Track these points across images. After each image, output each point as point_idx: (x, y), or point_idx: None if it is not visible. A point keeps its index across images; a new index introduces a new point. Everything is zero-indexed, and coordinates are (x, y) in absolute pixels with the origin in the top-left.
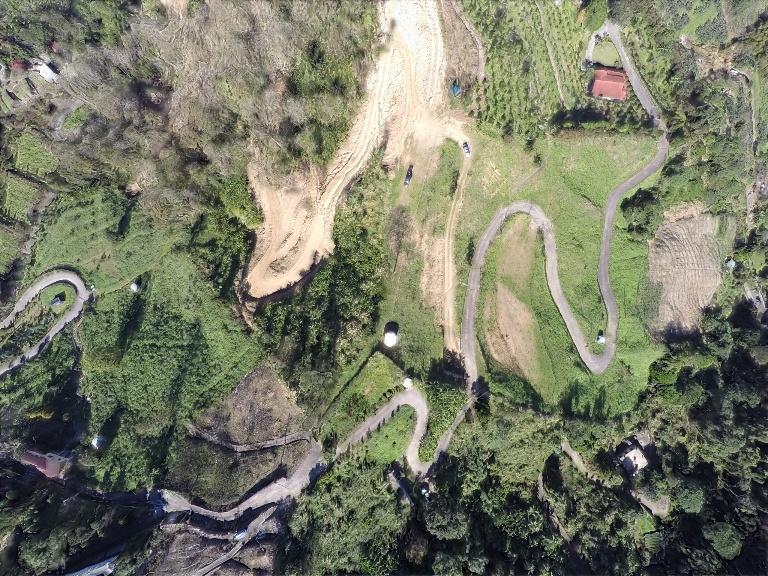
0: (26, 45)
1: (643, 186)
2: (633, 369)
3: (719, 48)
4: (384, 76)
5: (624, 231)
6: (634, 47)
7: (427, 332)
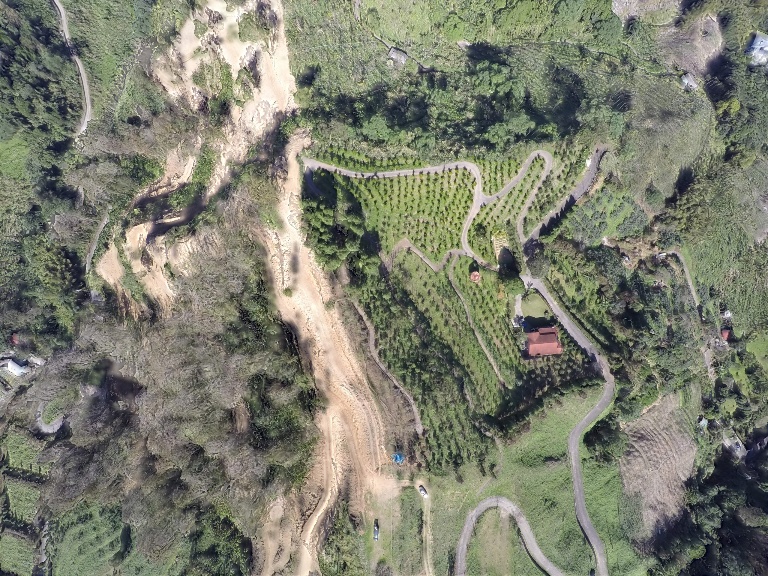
0: None
1: (600, 418)
2: None
3: (643, 231)
4: (330, 437)
5: (592, 461)
6: (560, 283)
7: None
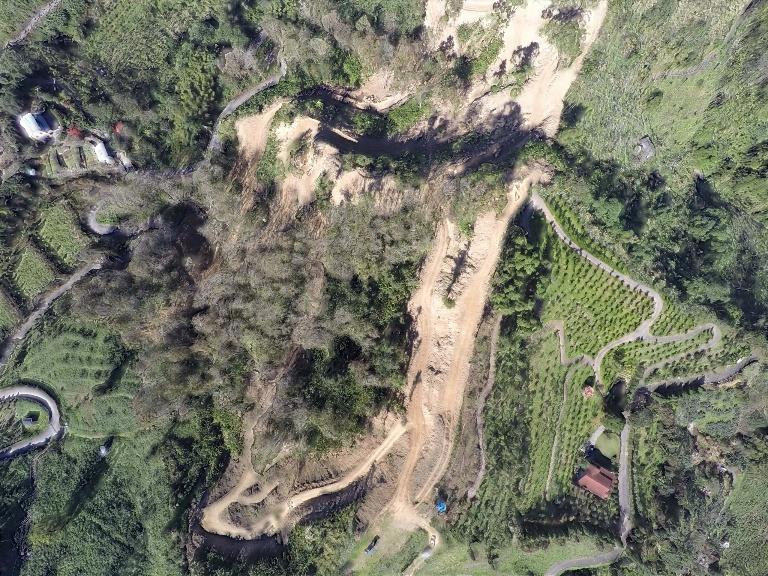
0: (91, 115)
1: None
2: None
3: (722, 439)
4: (389, 444)
5: None
6: (639, 439)
7: None
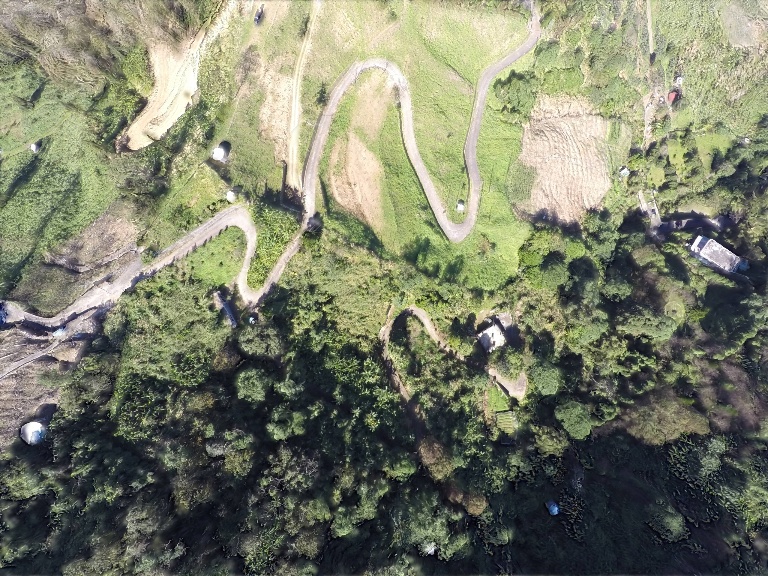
0: None
1: (517, 68)
2: (500, 250)
3: None
4: None
5: (497, 112)
6: None
7: (265, 161)
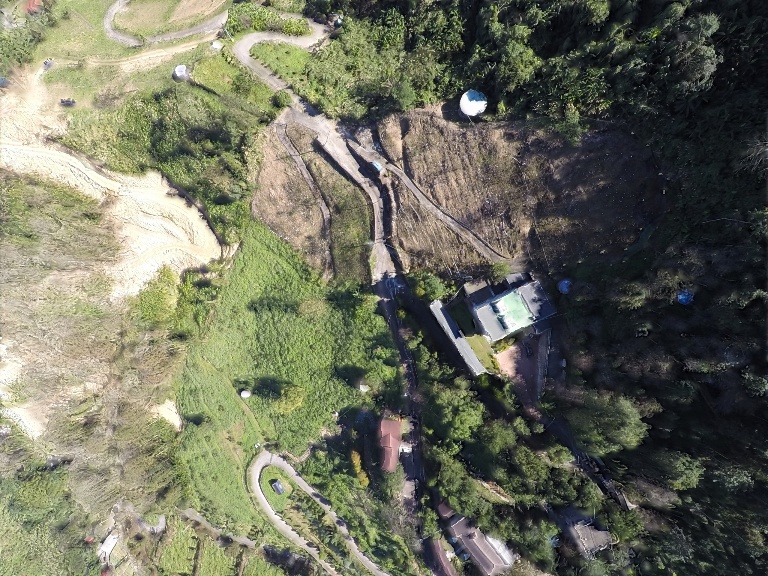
0: (87, 568)
1: None
2: None
3: None
4: (1, 143)
5: None
6: None
7: (191, 53)
